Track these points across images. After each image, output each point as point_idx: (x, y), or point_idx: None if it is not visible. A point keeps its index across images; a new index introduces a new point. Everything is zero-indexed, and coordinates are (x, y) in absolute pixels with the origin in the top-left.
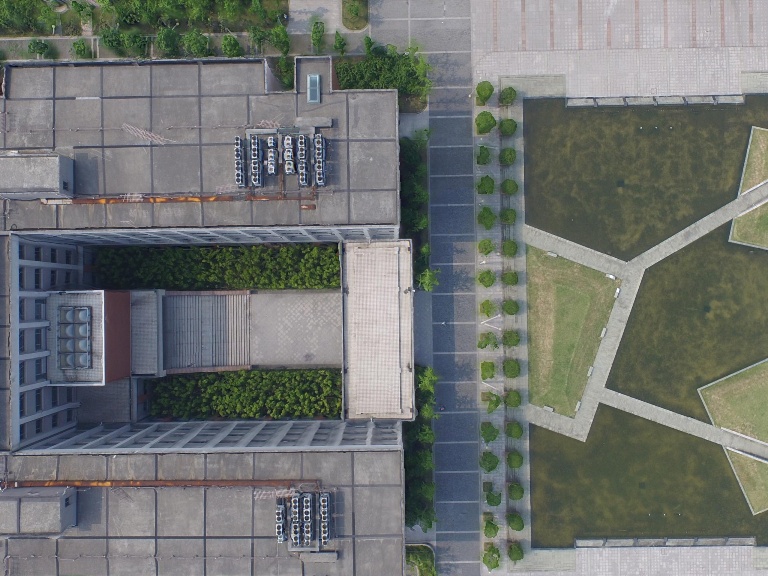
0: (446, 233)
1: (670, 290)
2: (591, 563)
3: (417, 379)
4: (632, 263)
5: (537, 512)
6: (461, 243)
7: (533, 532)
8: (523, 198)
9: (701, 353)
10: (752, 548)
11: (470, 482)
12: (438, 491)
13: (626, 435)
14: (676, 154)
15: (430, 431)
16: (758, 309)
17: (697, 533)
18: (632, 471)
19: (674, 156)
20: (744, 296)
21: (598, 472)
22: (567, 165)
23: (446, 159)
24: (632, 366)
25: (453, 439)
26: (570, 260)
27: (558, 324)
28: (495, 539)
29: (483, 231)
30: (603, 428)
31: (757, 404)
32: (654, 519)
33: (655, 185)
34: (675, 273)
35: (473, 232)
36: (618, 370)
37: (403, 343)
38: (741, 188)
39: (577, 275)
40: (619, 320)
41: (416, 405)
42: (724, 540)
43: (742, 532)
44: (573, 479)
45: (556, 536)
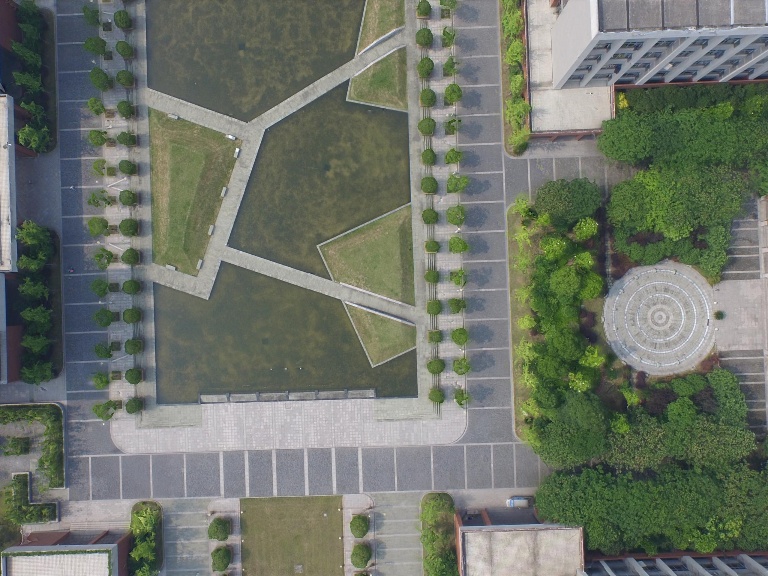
0: (74, 99)
1: (291, 150)
2: (217, 418)
3: (16, 231)
4: (252, 124)
5: (163, 369)
6: (88, 109)
7: (159, 389)
8: (145, 62)
9: (321, 211)
10: (373, 400)
11: (99, 342)
12: (68, 351)
13: (249, 292)
14: (296, 17)
15: (30, 282)
16: (377, 167)
17: (318, 386)
18: (255, 327)
19: (294, 19)
20: (363, 154)
21: (222, 329)
22: (189, 30)
23: (73, 27)
24: (254, 225)
25: (82, 300)
26: (191, 122)
27: (173, 182)
28: (123, 397)
29: (109, 96)
30: (226, 286)
31: (370, 257)
32: (277, 374)
33: (276, 47)
34: (296, 133)
35: (100, 98)
36: (241, 229)
37: (3, 197)
38: (358, 48)
39: (196, 136)
40: (240, 180)
41: (19, 258)
42: (344, 392)
43: (362, 385)
44: (198, 336)
45: (182, 392)
